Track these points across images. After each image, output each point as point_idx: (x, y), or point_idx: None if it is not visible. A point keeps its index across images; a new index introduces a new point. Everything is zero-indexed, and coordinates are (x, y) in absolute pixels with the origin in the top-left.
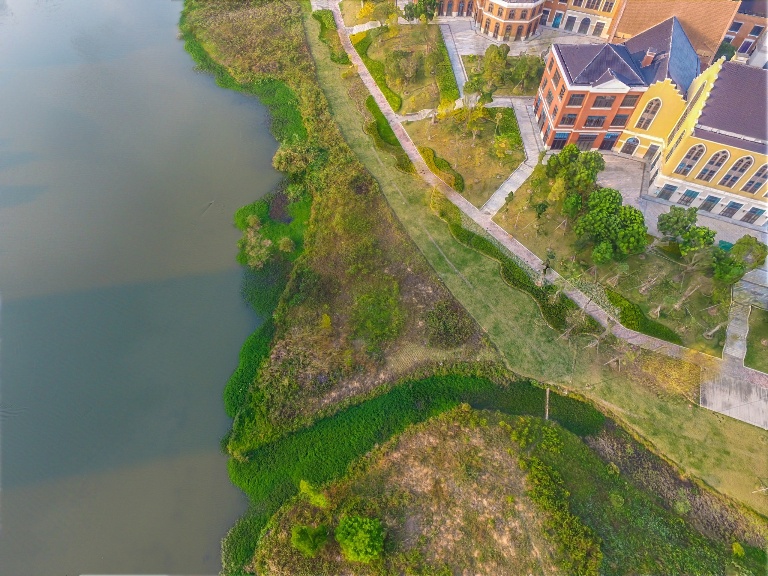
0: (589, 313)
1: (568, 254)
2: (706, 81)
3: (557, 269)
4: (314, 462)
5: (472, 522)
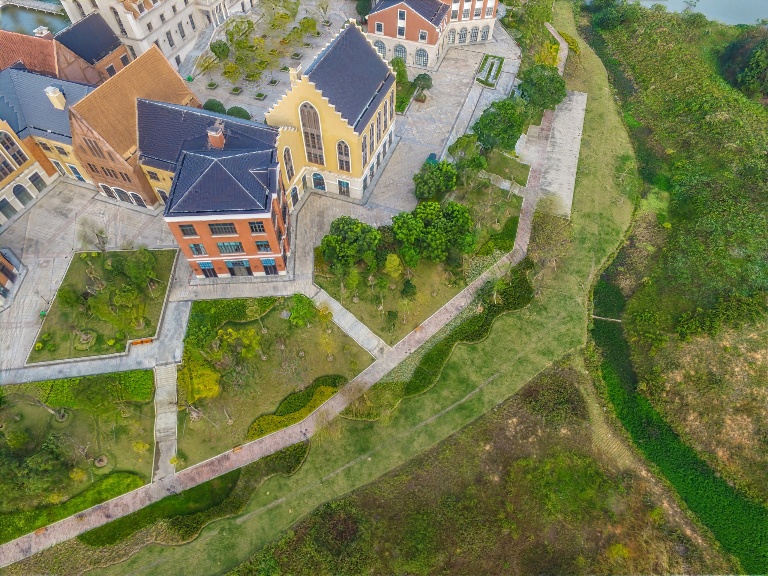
0: (503, 273)
1: (440, 278)
2: (307, 102)
3: (457, 291)
4: (767, 545)
5: (759, 380)
